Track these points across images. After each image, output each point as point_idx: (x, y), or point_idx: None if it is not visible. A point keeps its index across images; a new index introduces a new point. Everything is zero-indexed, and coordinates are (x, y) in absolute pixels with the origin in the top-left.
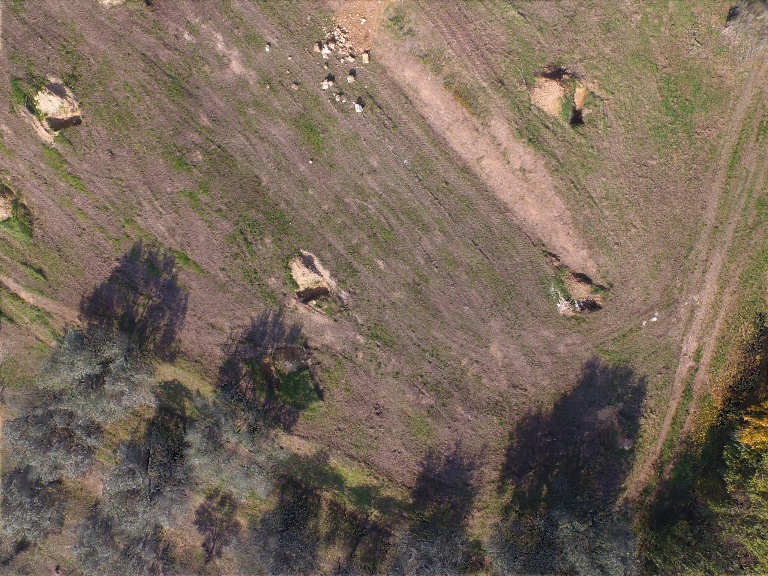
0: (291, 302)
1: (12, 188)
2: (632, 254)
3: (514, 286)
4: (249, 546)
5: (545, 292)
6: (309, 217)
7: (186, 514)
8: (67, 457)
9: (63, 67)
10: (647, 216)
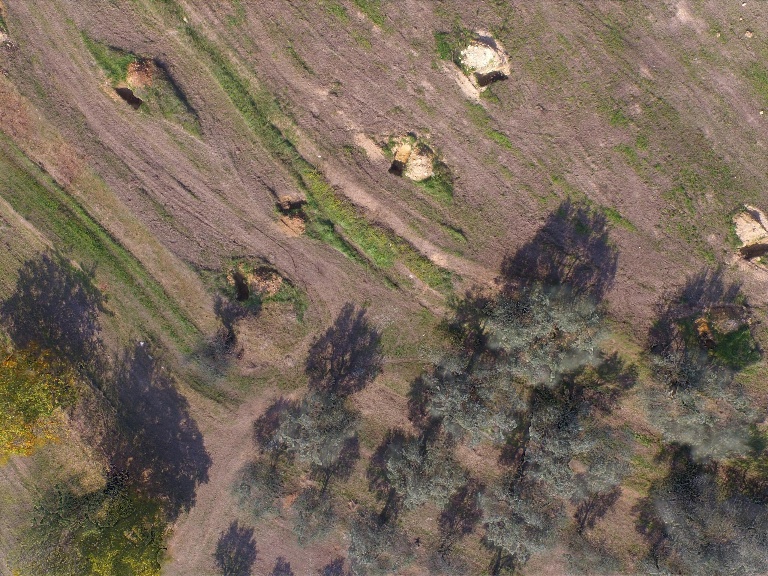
0: (732, 259)
1: (431, 146)
2: None
3: None
4: (624, 516)
5: None
6: (756, 170)
7: None
8: (506, 421)
9: (493, 20)
10: None
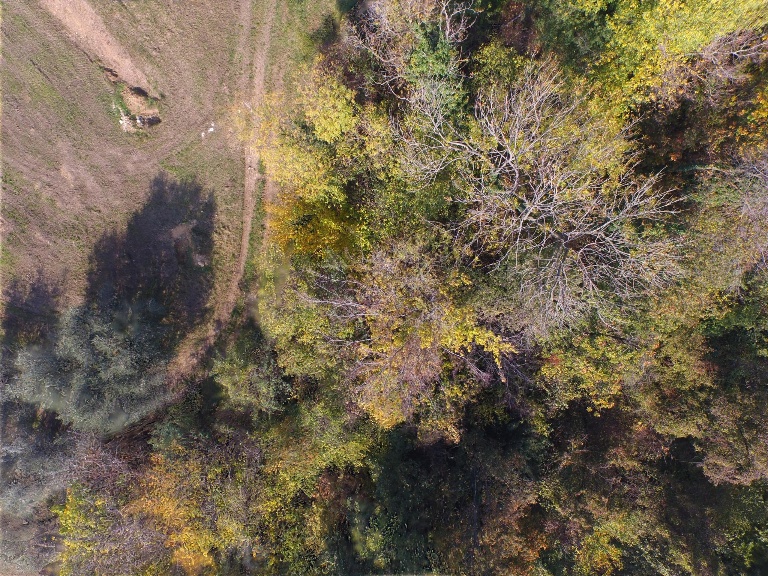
0: None
1: None
2: (174, 60)
3: (76, 105)
4: None
5: (107, 109)
6: None
7: None
8: None
9: None
10: (181, 19)
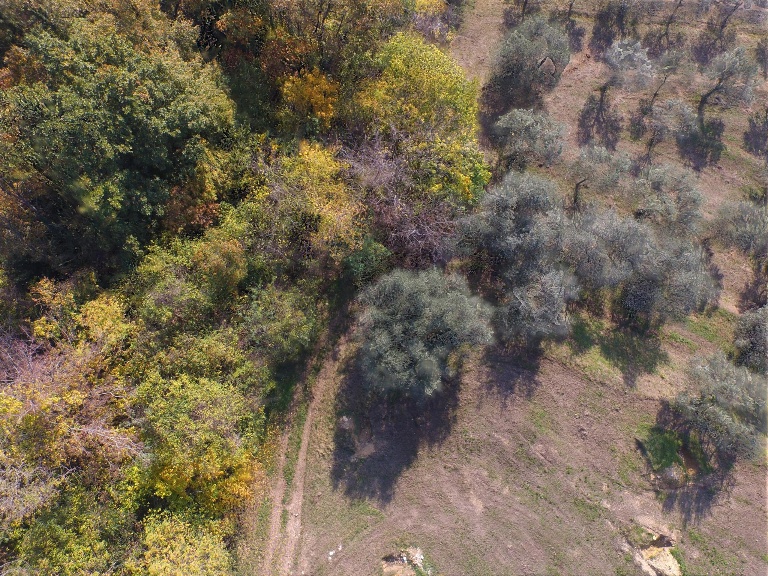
0: (676, 536)
1: None
2: None
3: (466, 572)
4: None
5: (436, 569)
6: None
7: (732, 285)
8: None
9: None
10: None
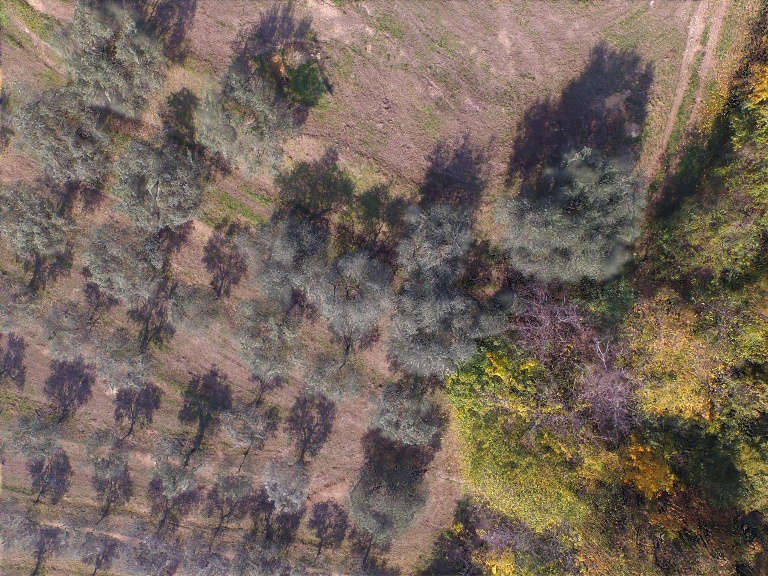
0: None
1: None
2: None
3: None
4: (257, 283)
5: None
6: None
7: (194, 251)
8: (77, 146)
9: None
10: None
